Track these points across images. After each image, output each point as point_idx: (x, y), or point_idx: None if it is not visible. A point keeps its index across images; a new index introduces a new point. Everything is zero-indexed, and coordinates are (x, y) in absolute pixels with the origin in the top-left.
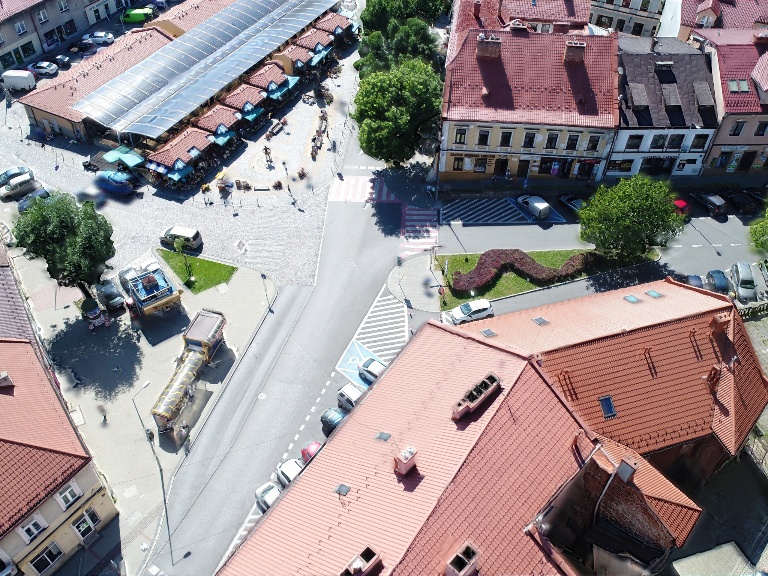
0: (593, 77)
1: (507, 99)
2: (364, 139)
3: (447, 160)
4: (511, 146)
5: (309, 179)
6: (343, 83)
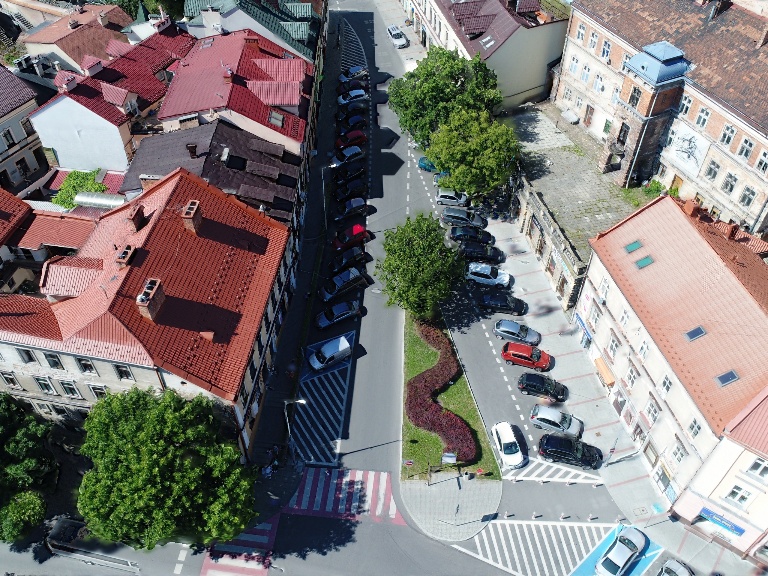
0: (224, 220)
1: (225, 316)
2: (238, 524)
3: (246, 430)
4: None
5: None
6: None
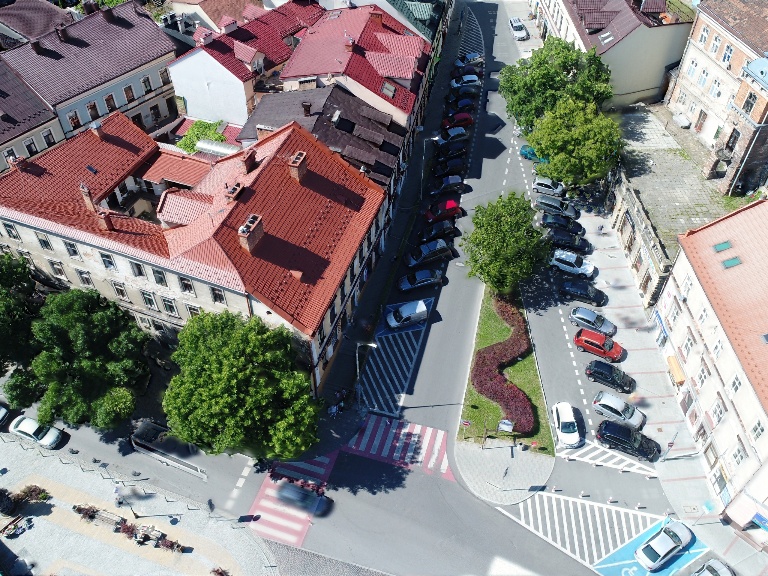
0: (326, 174)
1: (315, 260)
2: (300, 444)
3: (319, 369)
4: (346, 294)
5: (236, 568)
6: (1, 463)
